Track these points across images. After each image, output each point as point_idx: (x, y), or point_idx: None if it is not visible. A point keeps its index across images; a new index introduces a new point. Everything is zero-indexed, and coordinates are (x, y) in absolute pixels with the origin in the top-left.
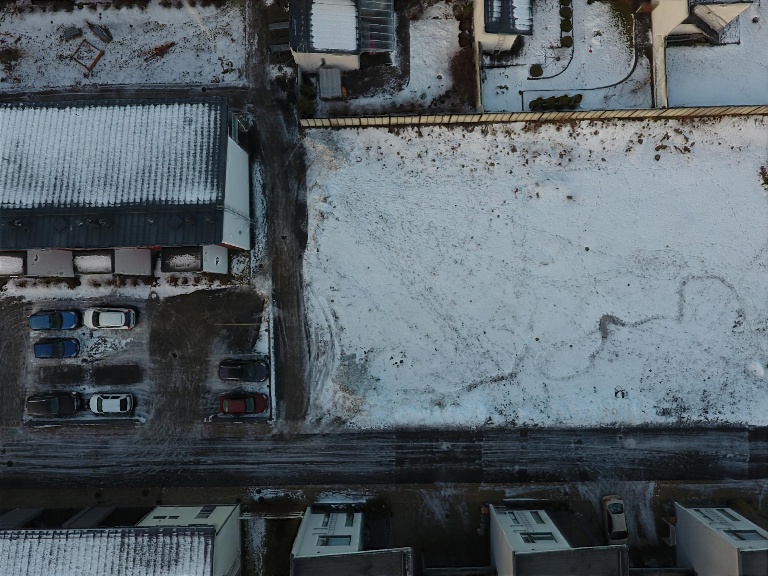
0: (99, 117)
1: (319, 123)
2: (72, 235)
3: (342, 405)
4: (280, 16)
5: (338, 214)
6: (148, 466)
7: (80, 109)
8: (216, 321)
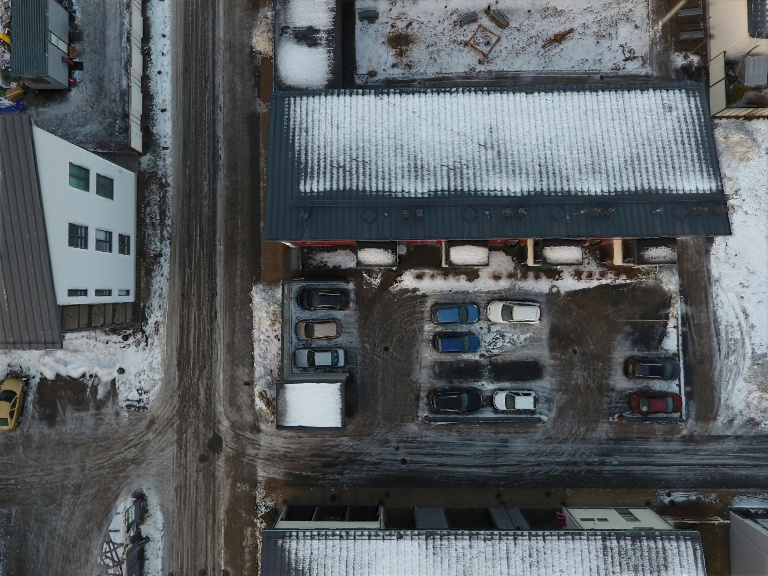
0: (572, 102)
1: (736, 113)
2: (570, 224)
3: (756, 406)
4: (685, 2)
5: (747, 207)
6: (550, 466)
7: (549, 94)
8: (619, 317)
